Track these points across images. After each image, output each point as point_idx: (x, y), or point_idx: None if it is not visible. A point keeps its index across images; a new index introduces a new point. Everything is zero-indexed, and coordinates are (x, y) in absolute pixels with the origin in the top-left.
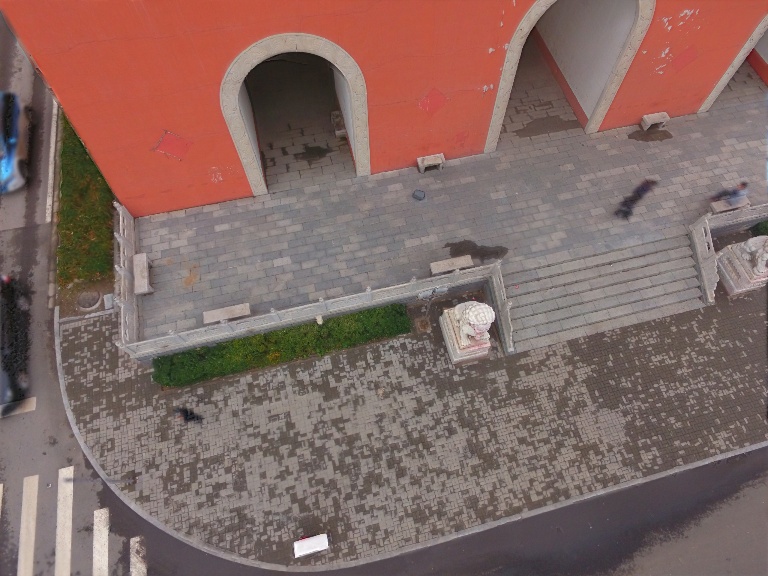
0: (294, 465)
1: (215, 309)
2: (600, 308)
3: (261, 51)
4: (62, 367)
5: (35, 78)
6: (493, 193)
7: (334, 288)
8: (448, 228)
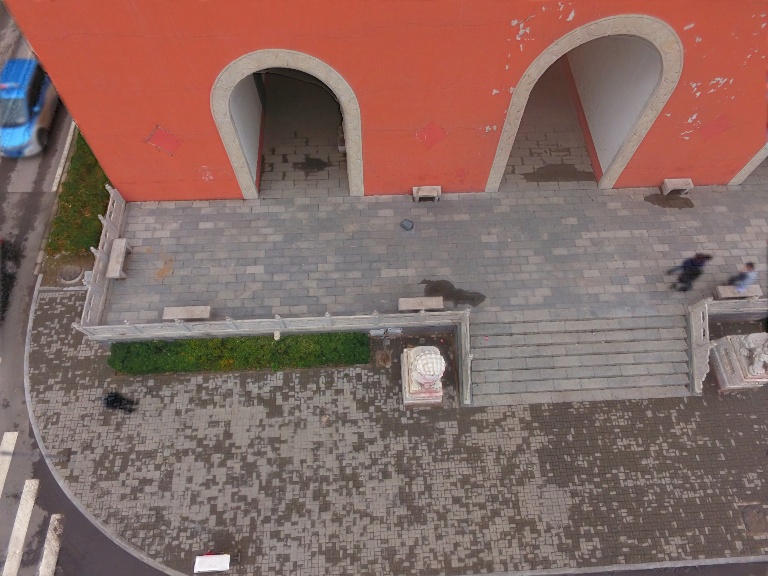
0: (222, 476)
1: (176, 306)
2: (572, 376)
3: (252, 63)
4: (31, 334)
5: None
6: (484, 235)
7: (299, 306)
8: (429, 264)
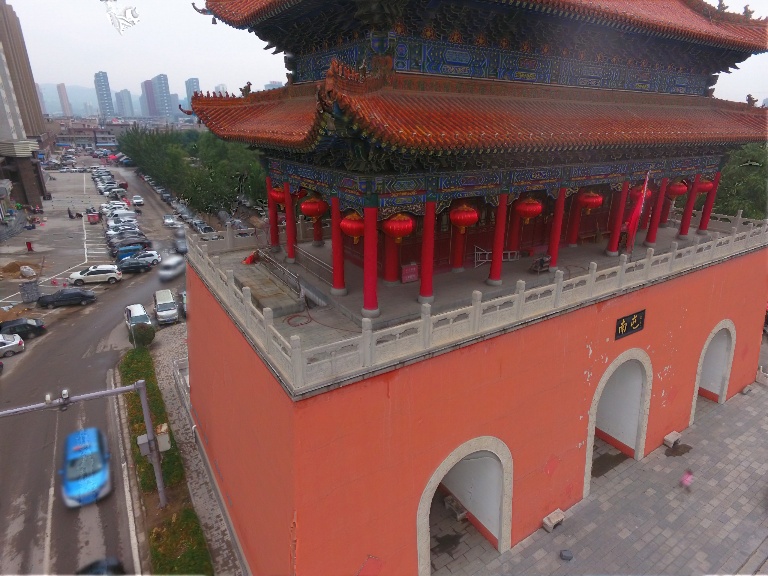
0: None
1: None
2: None
3: (454, 458)
4: None
5: (107, 548)
6: (619, 533)
7: None
8: None
